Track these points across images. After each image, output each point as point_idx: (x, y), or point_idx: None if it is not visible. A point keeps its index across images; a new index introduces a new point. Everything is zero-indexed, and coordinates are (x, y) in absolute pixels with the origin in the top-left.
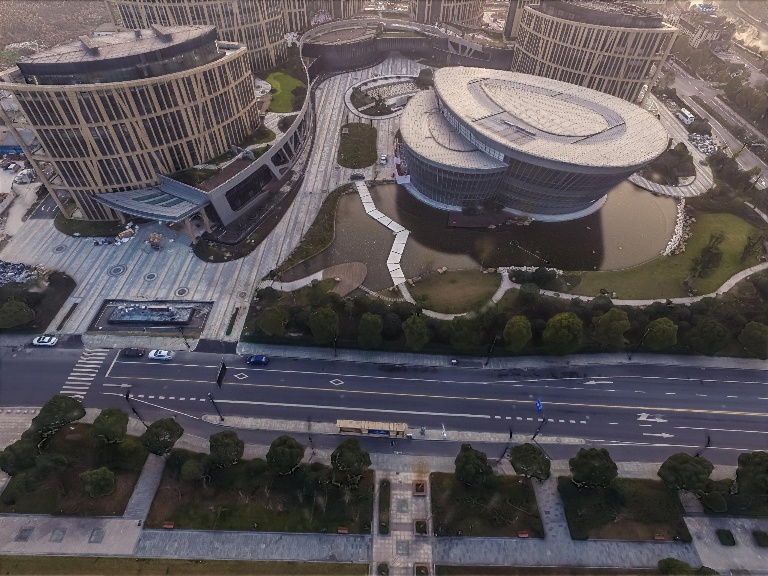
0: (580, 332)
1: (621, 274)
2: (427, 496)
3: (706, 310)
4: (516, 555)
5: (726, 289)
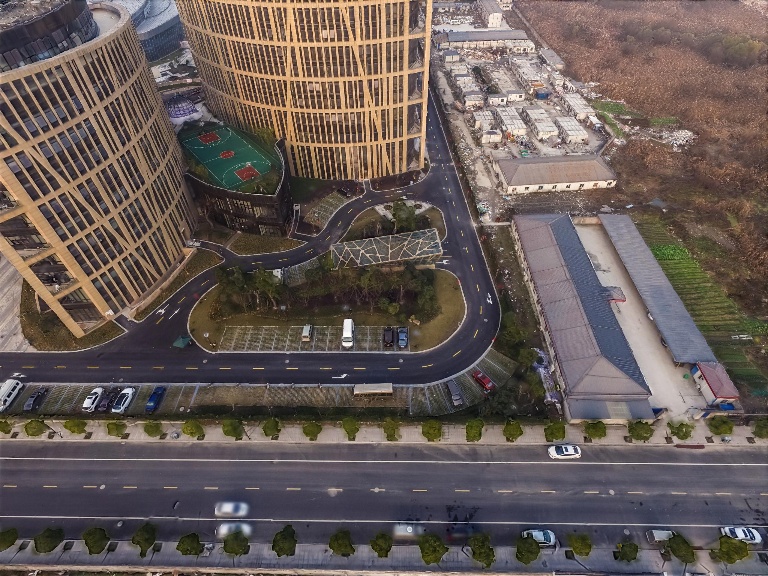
0: None
1: None
2: None
3: None
4: None
5: None
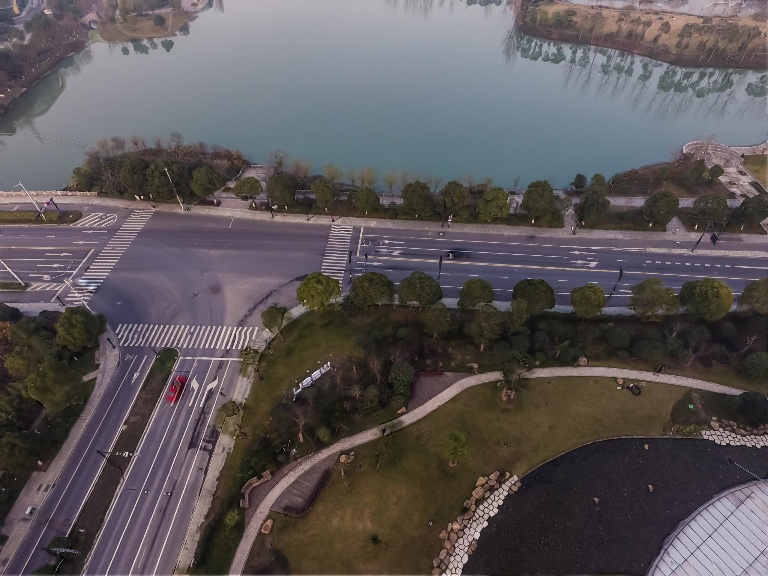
0: (697, 281)
1: (603, 429)
2: (762, 224)
3: (515, 334)
4: (687, 202)
5: (448, 392)
